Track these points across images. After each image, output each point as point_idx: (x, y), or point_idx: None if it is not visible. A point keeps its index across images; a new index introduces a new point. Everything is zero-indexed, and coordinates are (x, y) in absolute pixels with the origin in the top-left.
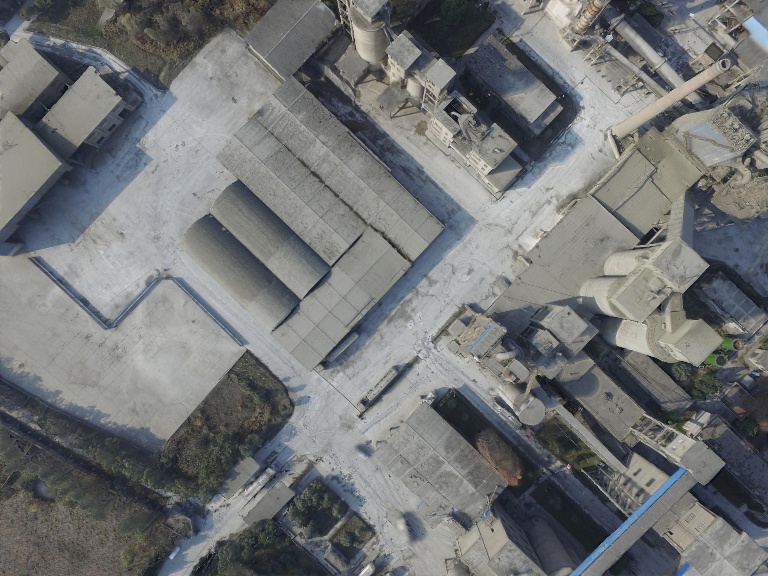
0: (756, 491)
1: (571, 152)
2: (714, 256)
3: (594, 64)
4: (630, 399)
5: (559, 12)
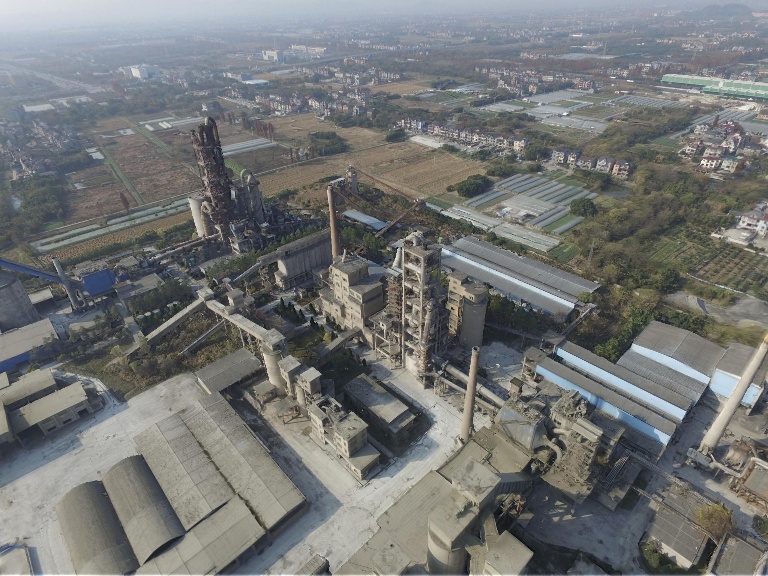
0: None
1: (428, 451)
2: (579, 547)
3: (442, 396)
4: None
5: (412, 366)
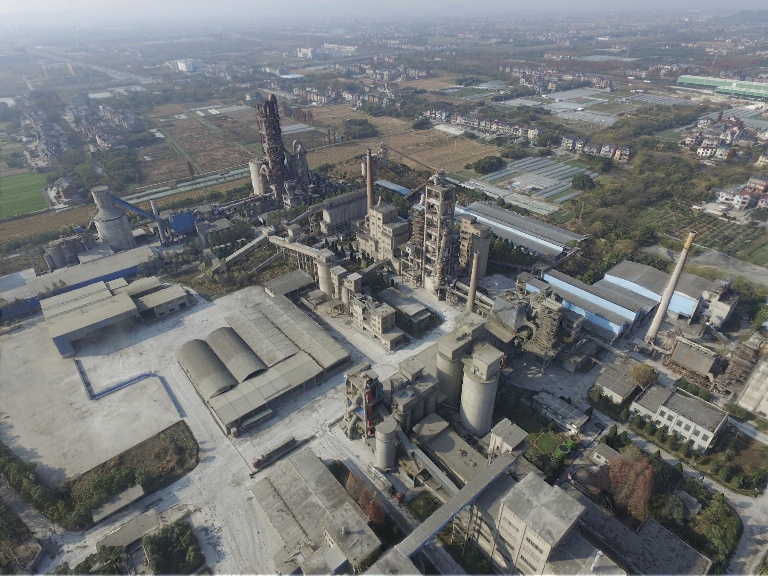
0: (627, 556)
1: (439, 337)
2: None
3: (452, 306)
4: (482, 456)
5: (430, 285)
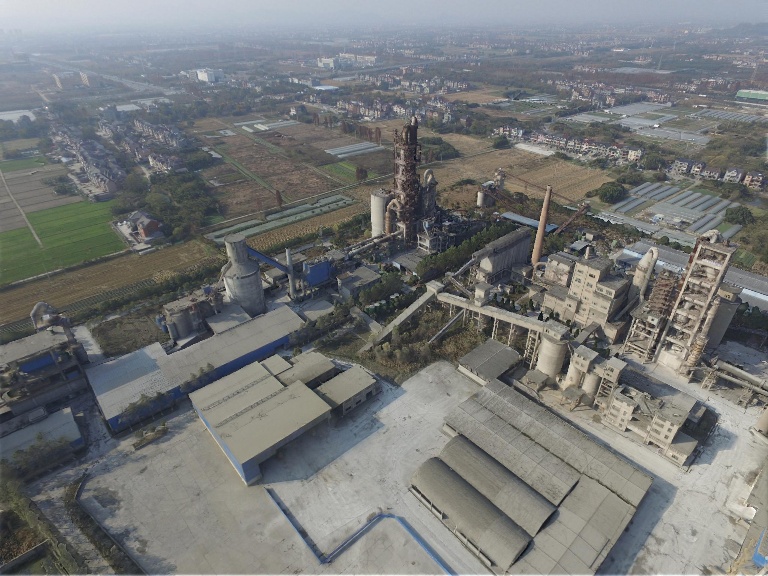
0: None
1: (730, 441)
2: None
3: (710, 391)
4: None
5: (669, 361)
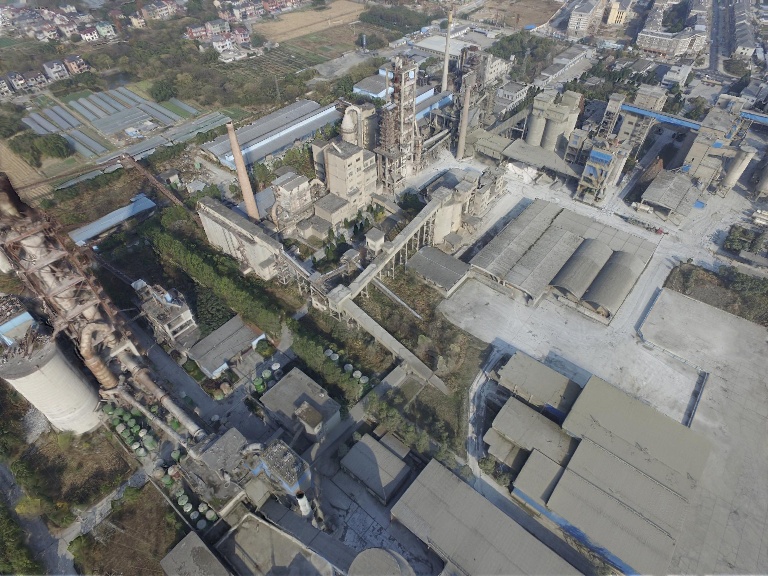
0: None
1: None
2: None
3: None
4: None
5: None
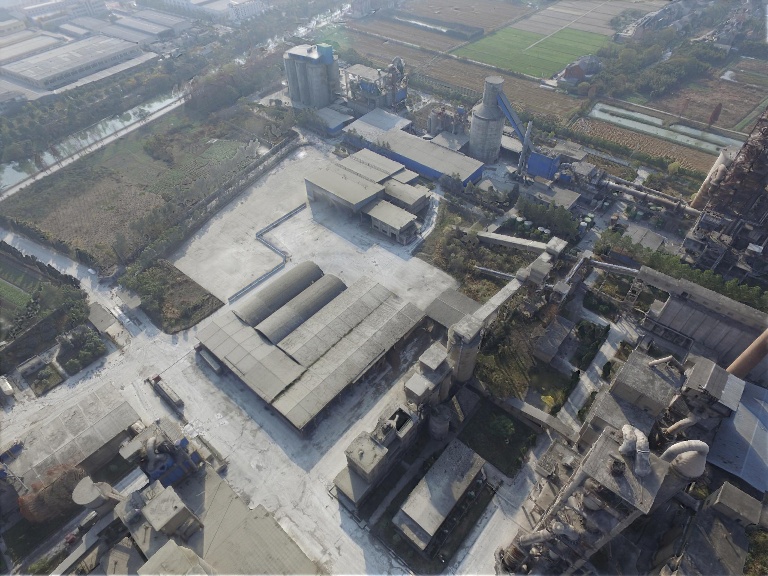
0: None
1: None
2: None
3: None
4: None
5: None
